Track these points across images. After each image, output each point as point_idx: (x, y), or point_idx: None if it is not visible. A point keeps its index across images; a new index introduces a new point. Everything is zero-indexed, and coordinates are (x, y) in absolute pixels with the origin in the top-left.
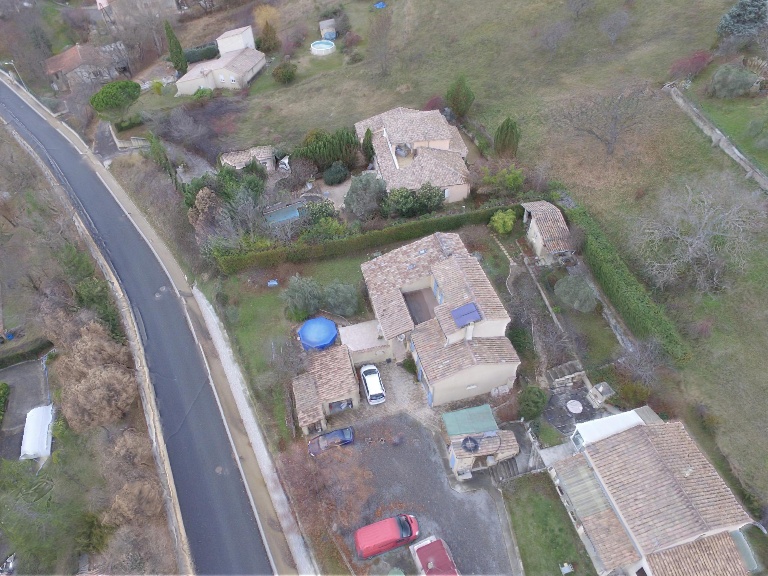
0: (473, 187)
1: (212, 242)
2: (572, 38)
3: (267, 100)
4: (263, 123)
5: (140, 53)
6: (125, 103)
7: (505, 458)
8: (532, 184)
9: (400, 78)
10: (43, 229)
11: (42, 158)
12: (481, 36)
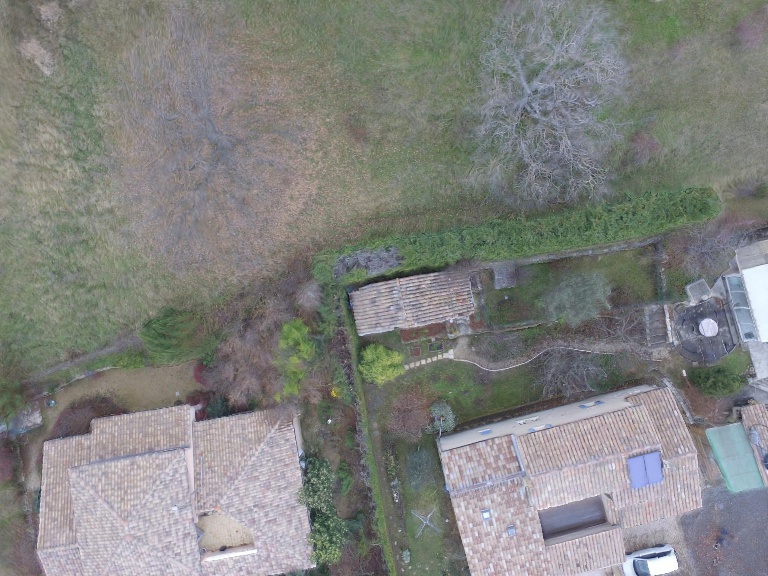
0: None
1: None
2: None
3: None
4: None
5: None
6: None
7: None
8: (304, 305)
9: None
10: None
11: None
12: None
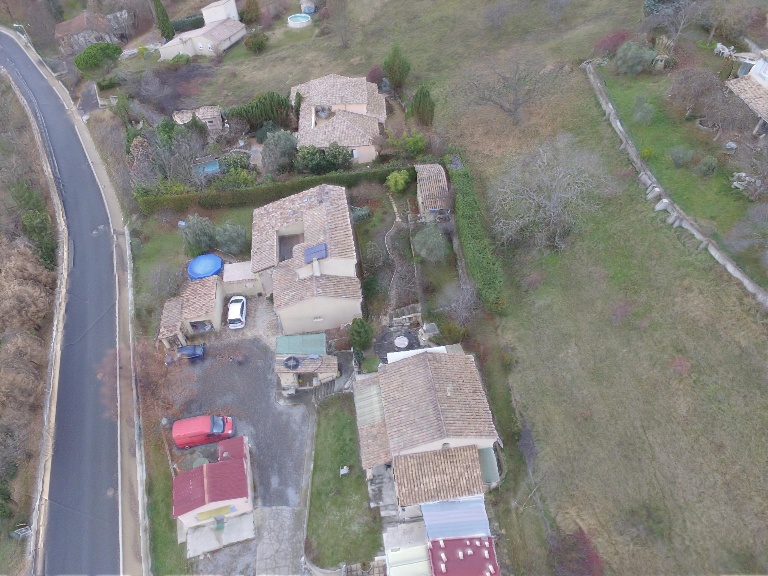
0: (378, 149)
1: (136, 184)
2: (523, 17)
3: (236, 67)
4: (225, 87)
5: (134, 20)
6: (104, 63)
7: (326, 379)
8: (432, 149)
9: (357, 50)
10: (7, 168)
11: (32, 111)
12: (442, 13)
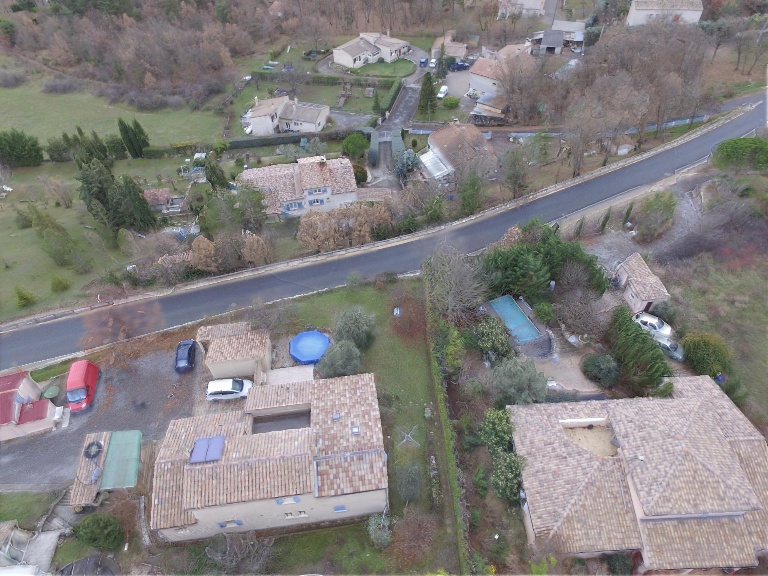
0: None
1: None
2: None
3: None
4: (762, 295)
5: None
6: (731, 162)
7: None
8: None
9: None
10: None
11: None
12: None
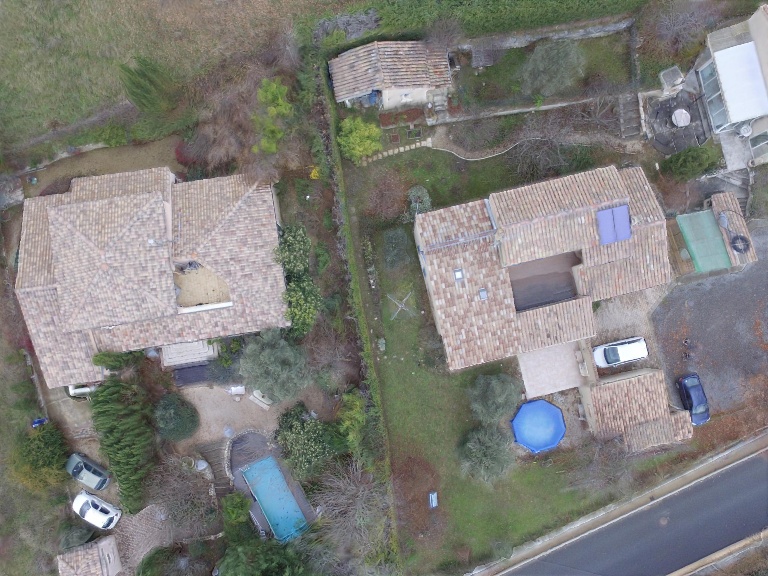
0: (277, 174)
1: None
2: None
3: None
4: None
5: None
6: None
7: None
8: (284, 71)
9: None
10: None
11: None
12: None
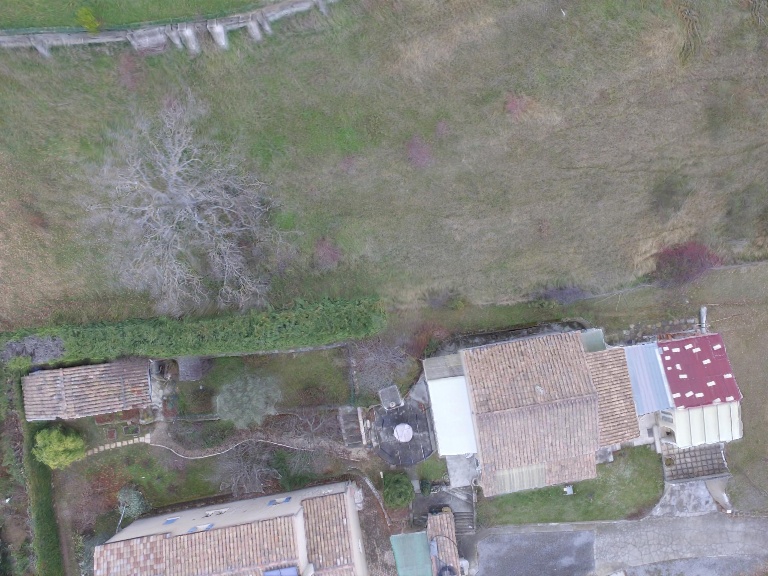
0: None
1: None
2: None
3: None
4: None
5: None
6: None
7: None
8: None
9: None
10: None
11: None
12: None
